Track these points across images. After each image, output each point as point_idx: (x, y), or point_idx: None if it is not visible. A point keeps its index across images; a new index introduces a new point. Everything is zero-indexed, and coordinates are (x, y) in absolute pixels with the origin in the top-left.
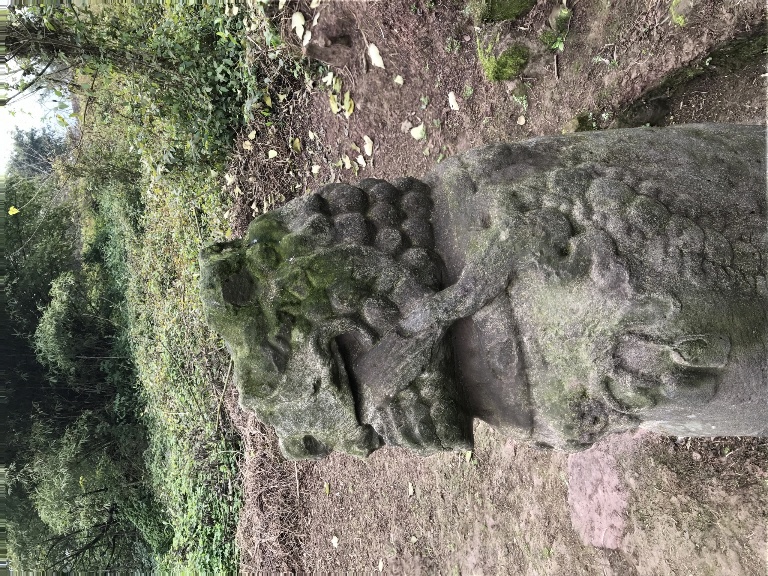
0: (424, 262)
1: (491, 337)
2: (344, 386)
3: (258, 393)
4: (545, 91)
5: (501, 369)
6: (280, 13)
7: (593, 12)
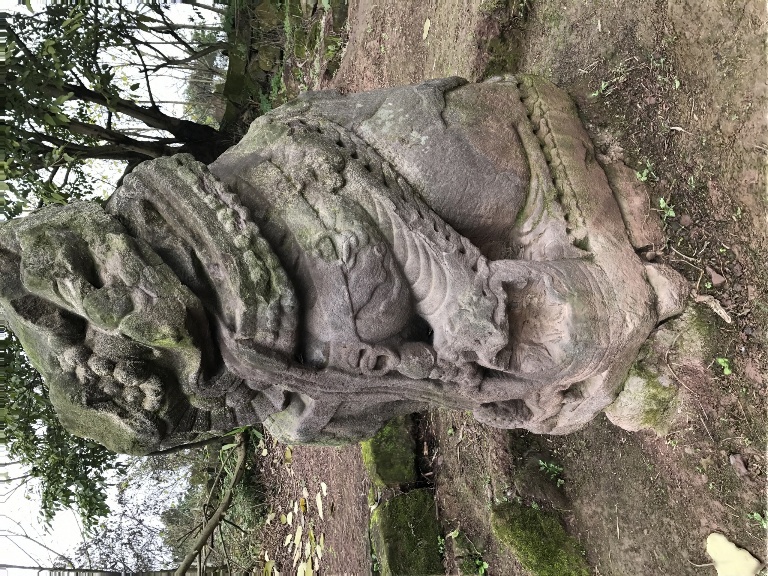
0: None
1: None
2: None
3: None
4: None
5: None
6: None
7: (468, 508)
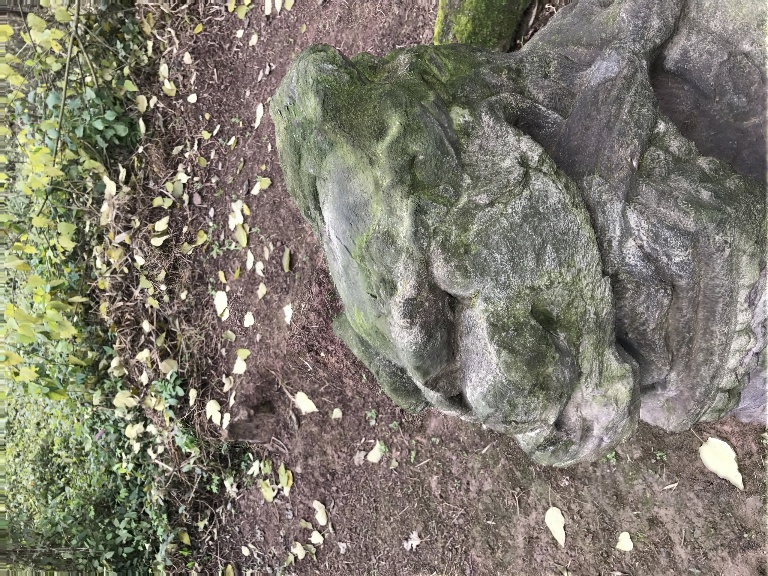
0: (564, 57)
1: (706, 65)
2: (560, 171)
3: (438, 198)
4: None
5: (745, 106)
6: (192, 408)
7: None
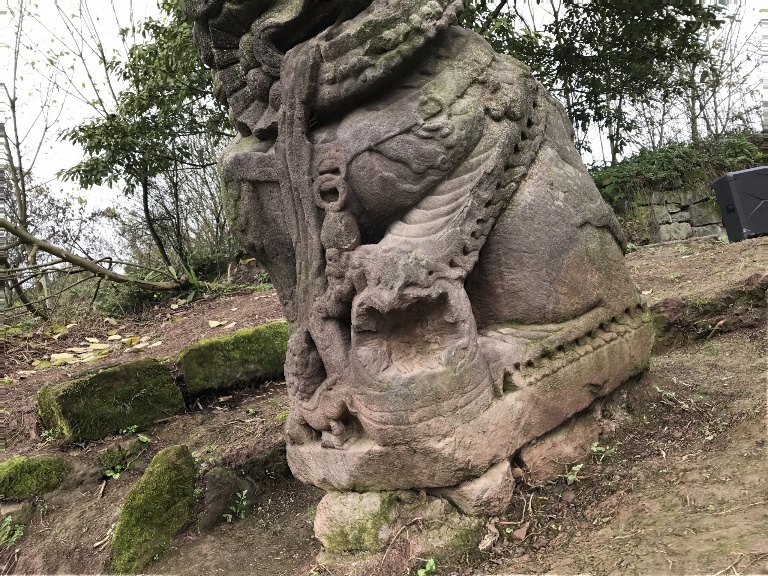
0: None
1: None
2: None
3: None
4: (70, 513)
5: None
6: None
7: None
